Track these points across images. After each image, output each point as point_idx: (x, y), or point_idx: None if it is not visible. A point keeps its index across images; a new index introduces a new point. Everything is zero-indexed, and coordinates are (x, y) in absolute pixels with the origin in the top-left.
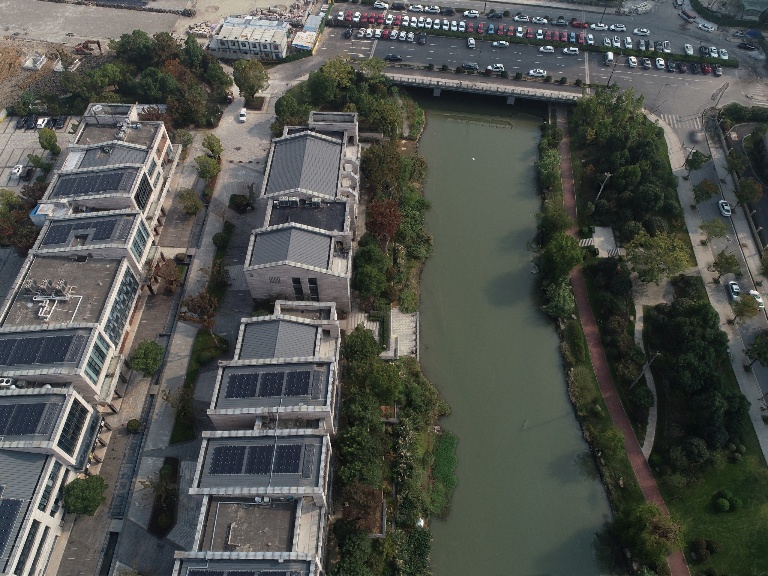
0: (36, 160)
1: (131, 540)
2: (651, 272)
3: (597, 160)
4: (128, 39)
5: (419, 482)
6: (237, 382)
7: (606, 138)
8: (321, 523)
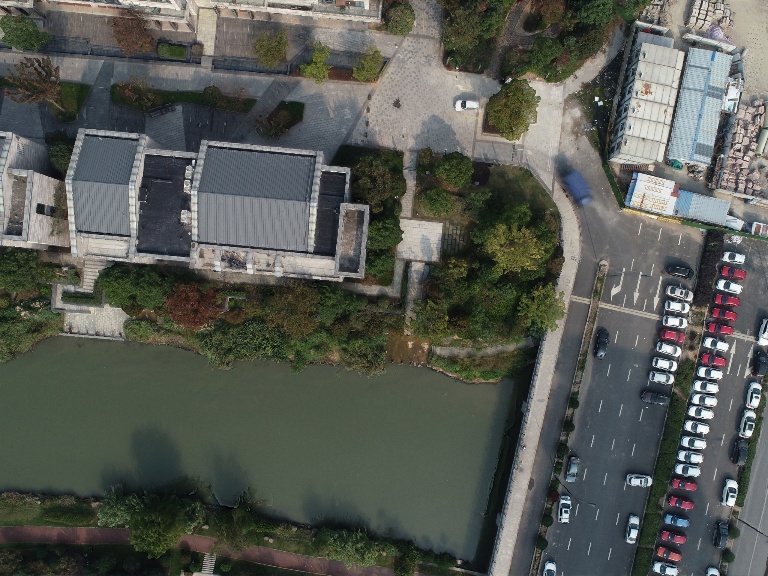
0: None
1: None
2: None
3: None
4: None
5: None
6: None
7: None
8: None
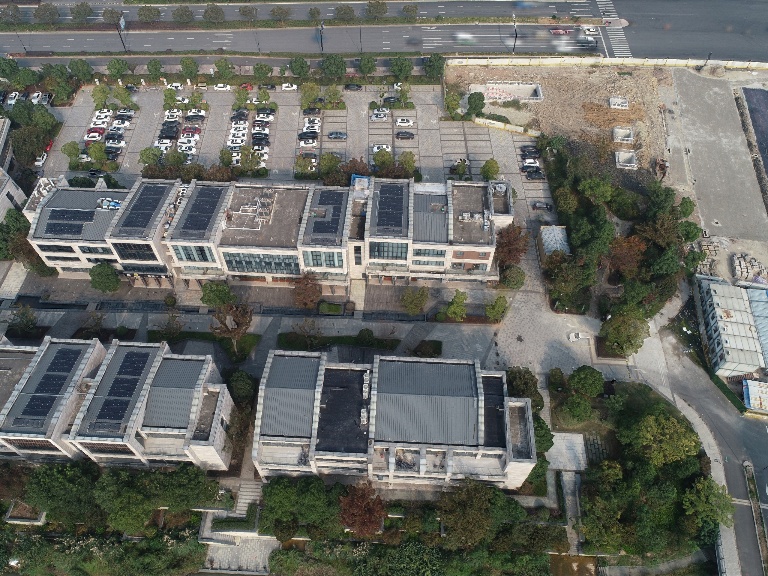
0: (459, 168)
1: (78, 318)
2: None
3: None
4: (662, 194)
5: (58, 564)
6: (139, 359)
7: None
8: (0, 448)
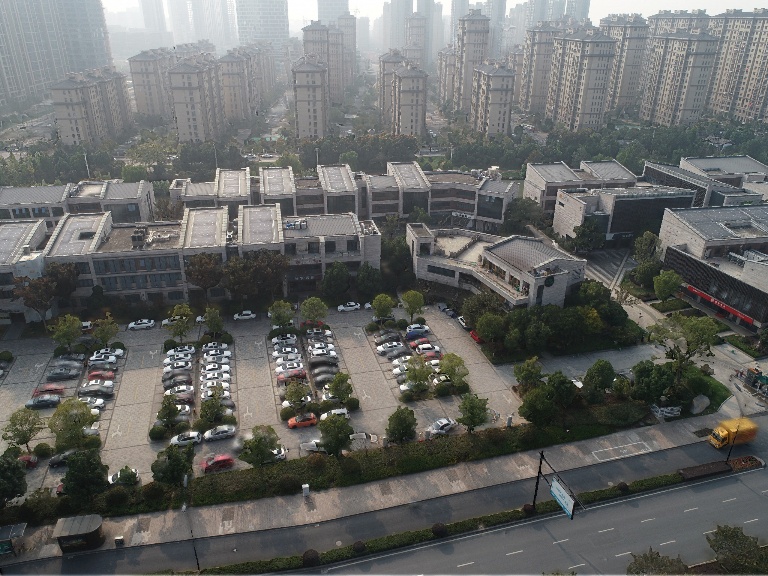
0: None
1: None
2: (159, 156)
3: (49, 180)
4: None
5: None
6: (229, 191)
7: (37, 168)
8: None
